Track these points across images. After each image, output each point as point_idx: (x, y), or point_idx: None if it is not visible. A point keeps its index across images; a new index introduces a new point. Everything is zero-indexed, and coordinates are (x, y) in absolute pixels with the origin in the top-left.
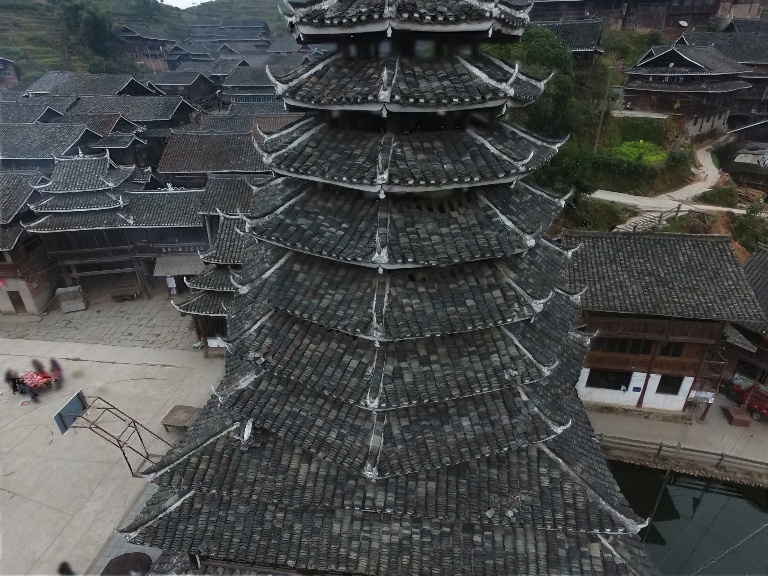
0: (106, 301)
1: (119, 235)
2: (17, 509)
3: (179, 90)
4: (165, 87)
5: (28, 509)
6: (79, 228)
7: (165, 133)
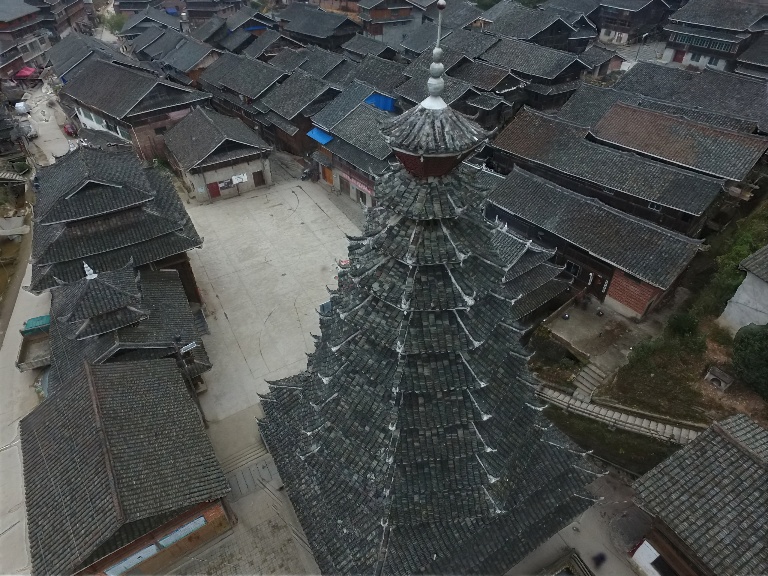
0: None
1: None
2: (297, 335)
3: (623, 15)
4: (612, 9)
5: (299, 338)
6: None
7: (543, 91)
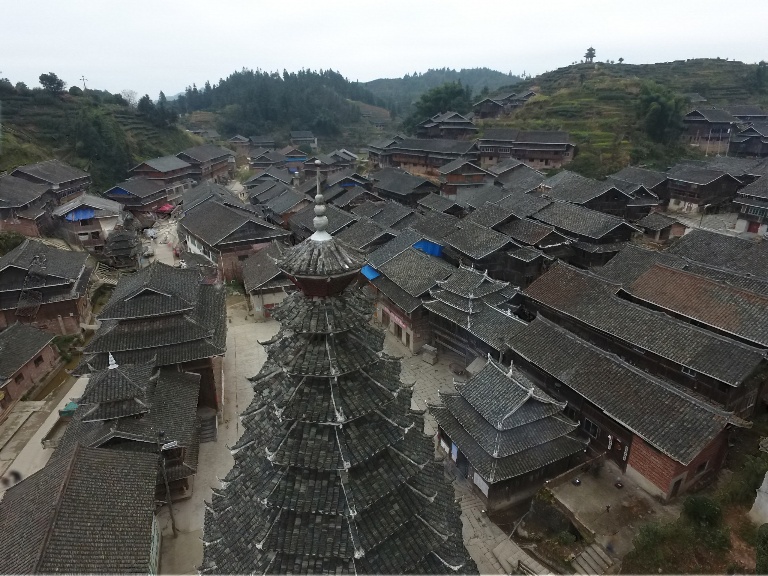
0: (447, 366)
1: (463, 330)
2: None
3: (691, 188)
4: (679, 182)
5: None
6: (444, 316)
7: (589, 249)
